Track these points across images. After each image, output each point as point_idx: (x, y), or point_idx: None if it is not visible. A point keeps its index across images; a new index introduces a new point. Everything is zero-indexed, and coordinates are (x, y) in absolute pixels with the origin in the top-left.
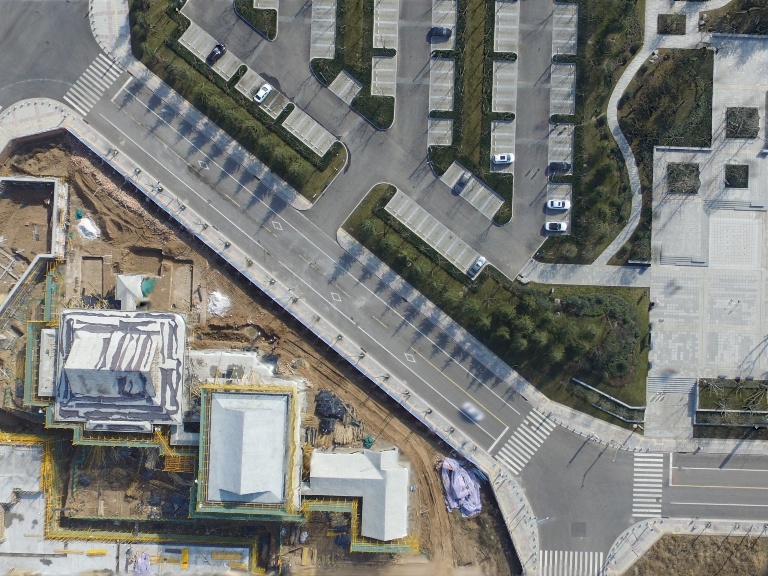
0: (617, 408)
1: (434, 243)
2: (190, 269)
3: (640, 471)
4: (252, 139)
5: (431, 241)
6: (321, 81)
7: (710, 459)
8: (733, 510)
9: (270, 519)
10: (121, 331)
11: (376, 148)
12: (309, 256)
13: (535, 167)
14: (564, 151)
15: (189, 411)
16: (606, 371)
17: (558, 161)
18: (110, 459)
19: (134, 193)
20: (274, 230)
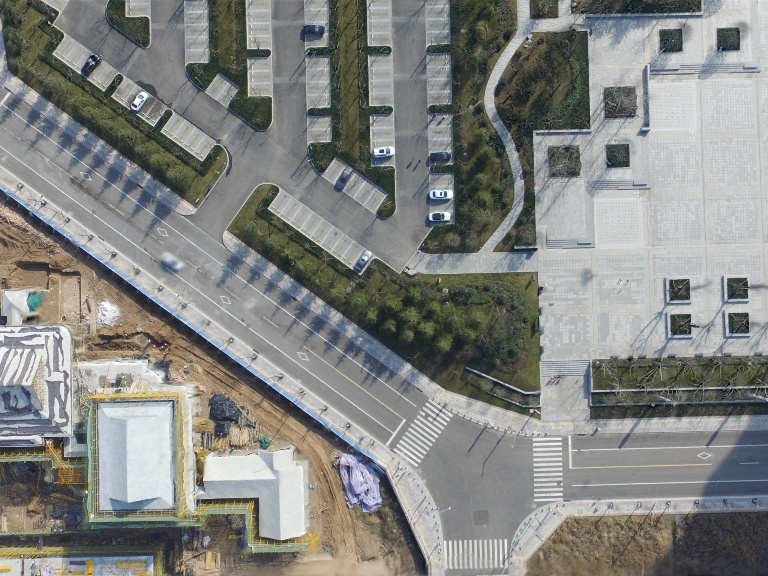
0: (512, 394)
1: (319, 240)
2: (78, 281)
3: (539, 456)
4: (129, 147)
5: (316, 239)
6: (197, 86)
7: (609, 440)
8: (635, 489)
9: (166, 525)
10: (5, 347)
11: (256, 149)
12: (196, 261)
13: (416, 159)
14: (444, 141)
15: (80, 422)
16: (497, 358)
17: (438, 151)
18: (10, 475)
19: (17, 208)
20: (160, 237)
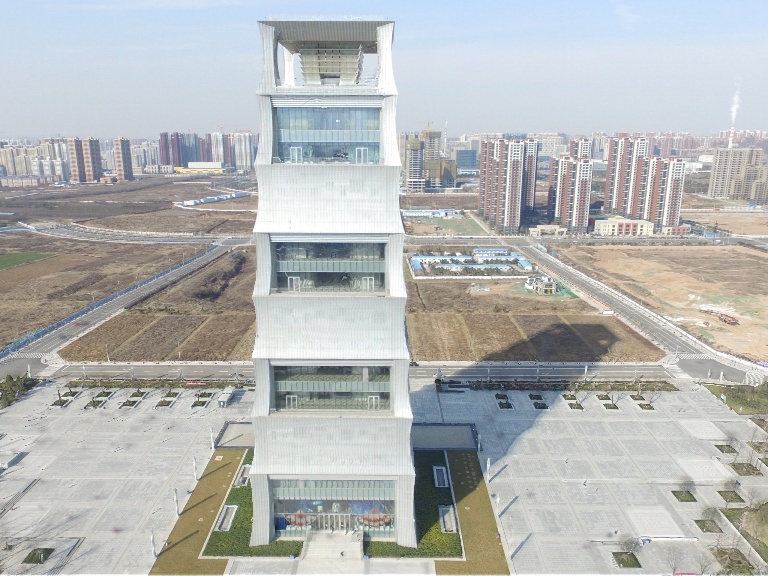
0: None
1: None
2: None
3: None
4: None
5: None
6: None
7: None
8: None
9: None
10: None
11: None
12: None
13: None
14: None
15: None
16: None
17: None
18: None
19: None
20: None
